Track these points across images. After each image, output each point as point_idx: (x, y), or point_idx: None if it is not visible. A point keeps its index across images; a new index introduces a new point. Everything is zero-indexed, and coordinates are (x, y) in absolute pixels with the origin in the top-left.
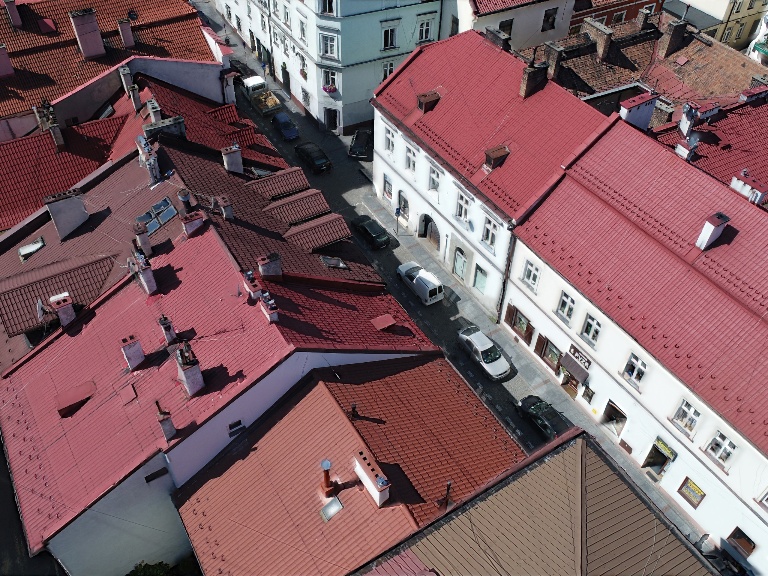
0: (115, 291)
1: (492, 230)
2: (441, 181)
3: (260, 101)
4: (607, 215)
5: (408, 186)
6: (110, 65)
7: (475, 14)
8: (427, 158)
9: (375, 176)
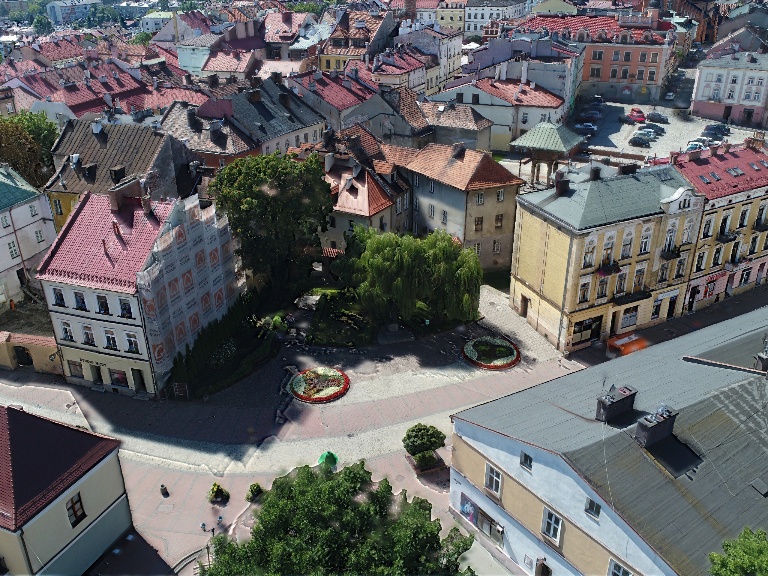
0: None
1: None
2: None
3: None
4: None
5: None
6: None
7: None
8: None
9: None
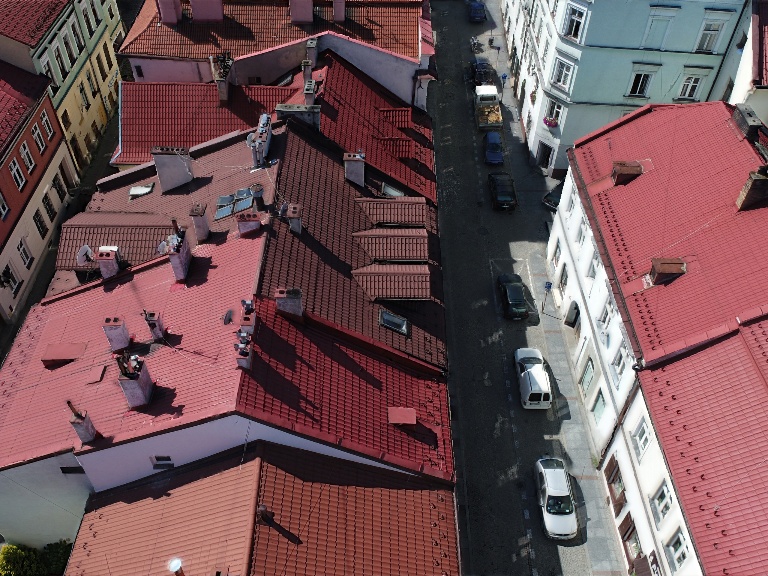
0: (158, 263)
1: (624, 358)
2: (598, 273)
3: (482, 113)
4: (765, 411)
5: (571, 262)
6: (312, 35)
7: (754, 83)
8: (593, 239)
9: (551, 236)
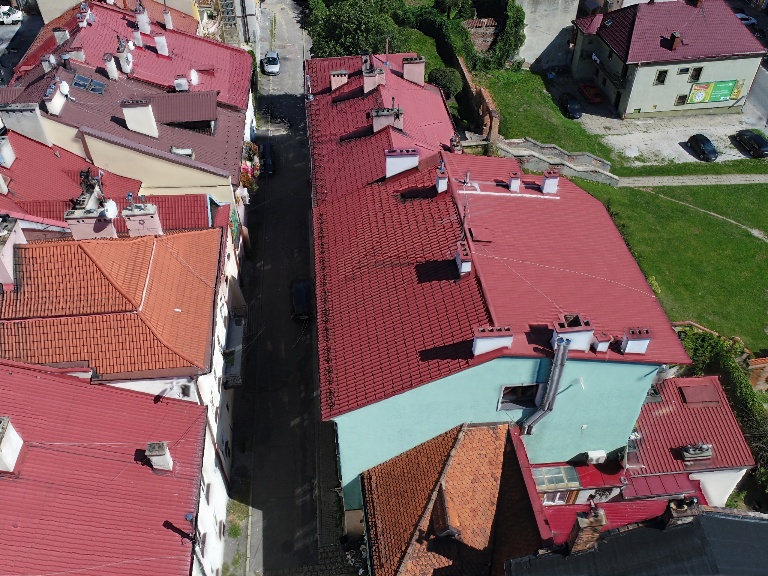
0: None
1: None
2: None
3: None
4: None
5: None
6: None
7: None
8: None
9: None
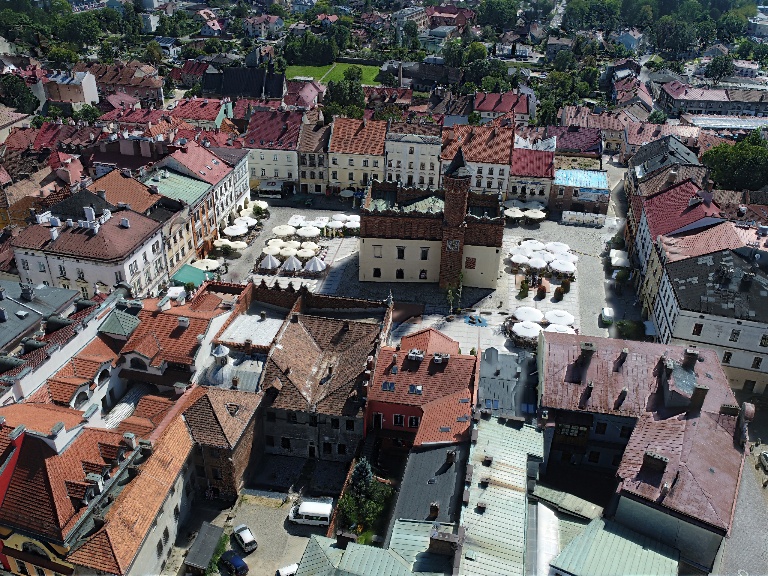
0: None
1: None
2: None
3: None
4: None
5: None
6: None
7: None
8: None
9: None
